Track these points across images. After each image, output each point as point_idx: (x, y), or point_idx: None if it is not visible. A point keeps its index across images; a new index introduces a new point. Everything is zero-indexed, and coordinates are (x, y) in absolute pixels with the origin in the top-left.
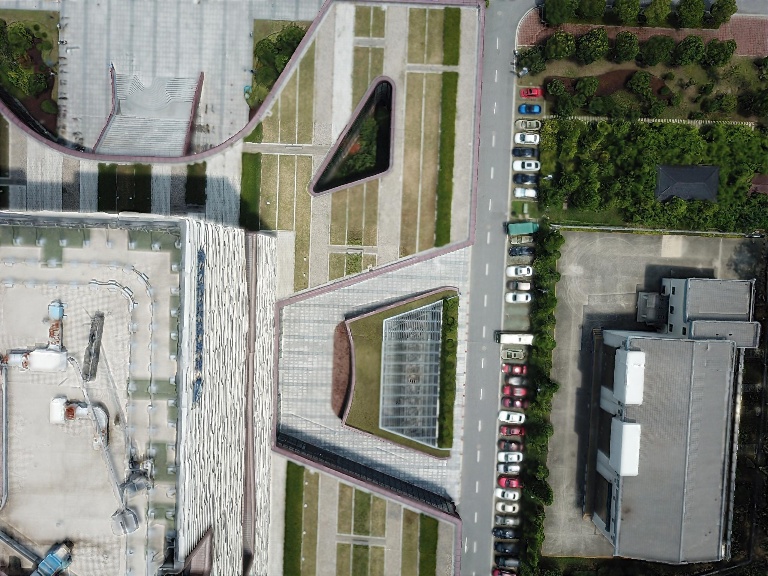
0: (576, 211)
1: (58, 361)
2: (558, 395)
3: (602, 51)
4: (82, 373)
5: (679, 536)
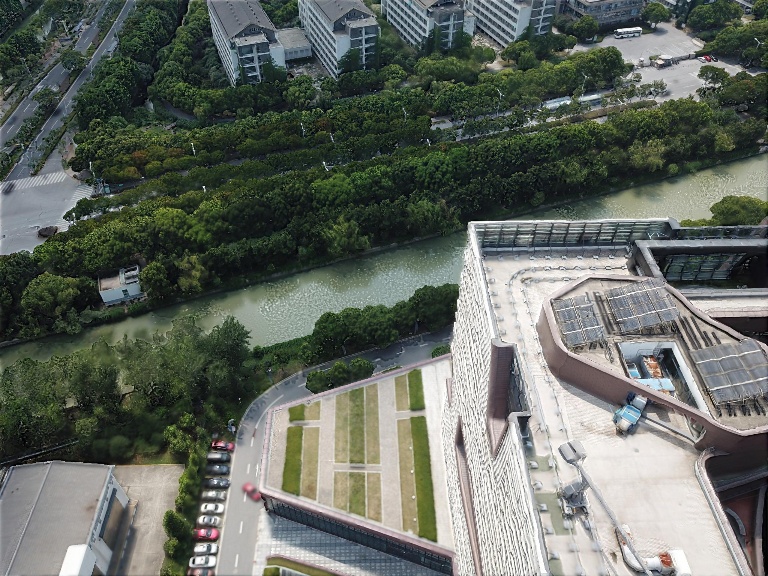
0: None
1: None
2: None
3: None
4: None
5: (45, 487)
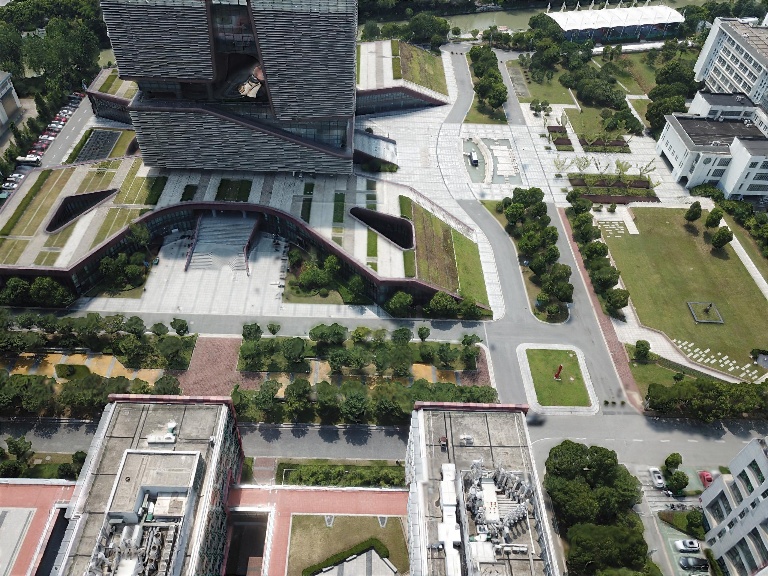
0: None
1: None
2: None
3: None
4: None
5: None
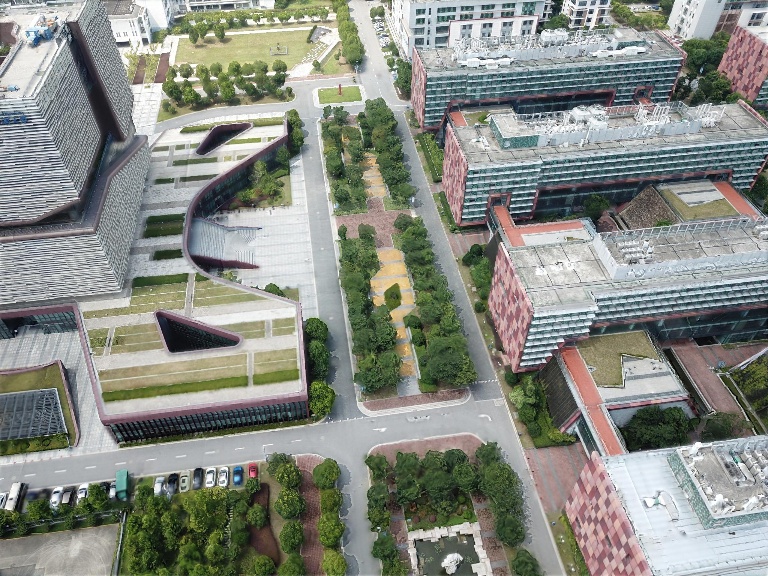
0: None
1: None
2: None
3: (281, 507)
4: None
5: None
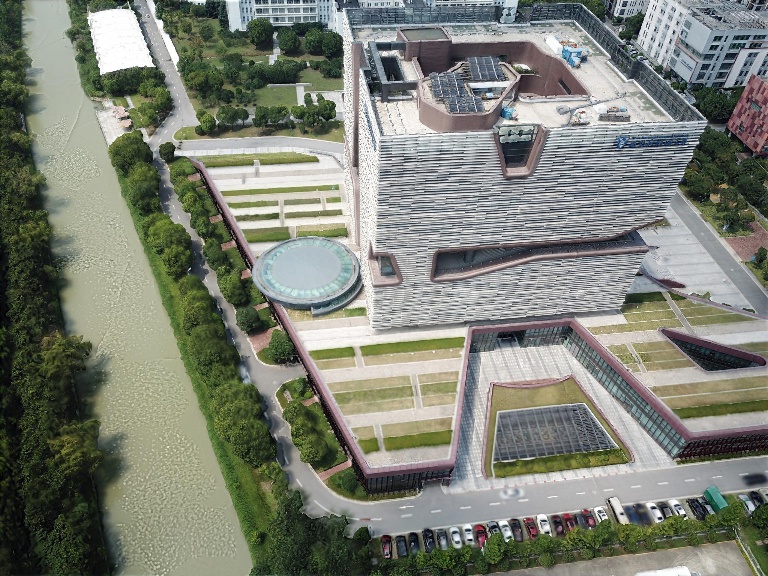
0: (762, 555)
1: (605, 108)
2: (583, 570)
3: None
4: (604, 114)
5: None
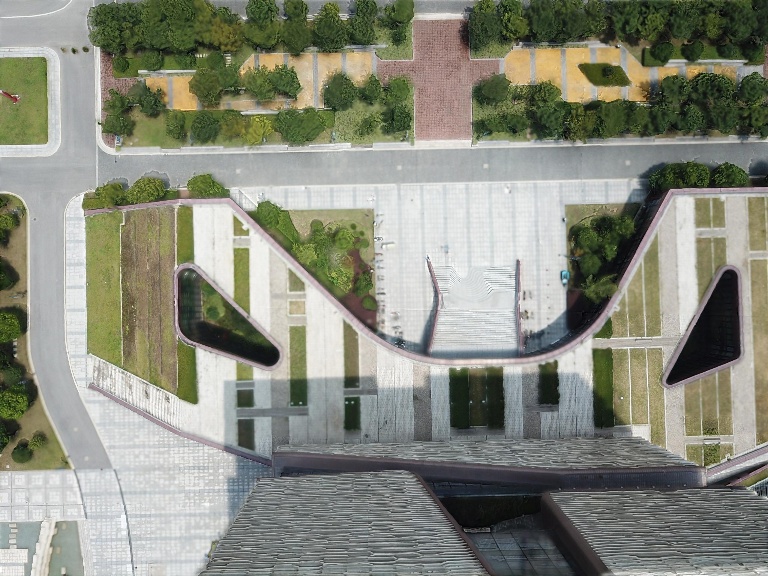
0: None
1: None
2: None
3: None
4: None
5: None
